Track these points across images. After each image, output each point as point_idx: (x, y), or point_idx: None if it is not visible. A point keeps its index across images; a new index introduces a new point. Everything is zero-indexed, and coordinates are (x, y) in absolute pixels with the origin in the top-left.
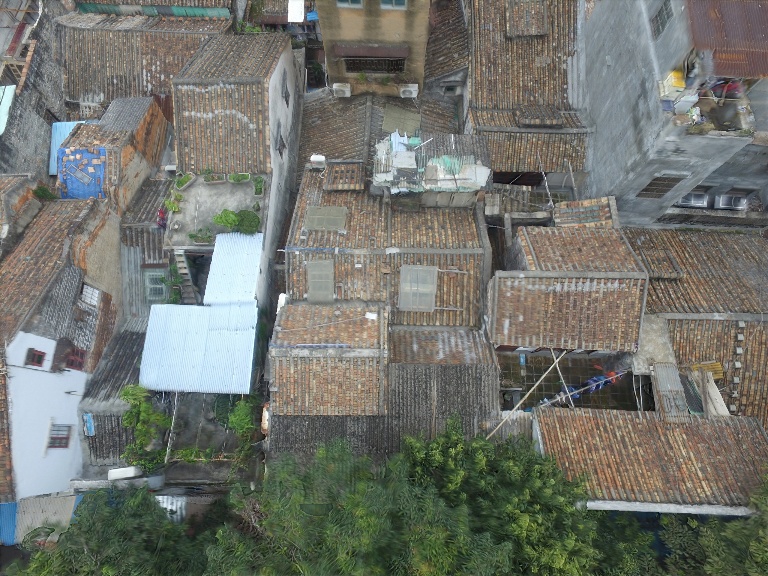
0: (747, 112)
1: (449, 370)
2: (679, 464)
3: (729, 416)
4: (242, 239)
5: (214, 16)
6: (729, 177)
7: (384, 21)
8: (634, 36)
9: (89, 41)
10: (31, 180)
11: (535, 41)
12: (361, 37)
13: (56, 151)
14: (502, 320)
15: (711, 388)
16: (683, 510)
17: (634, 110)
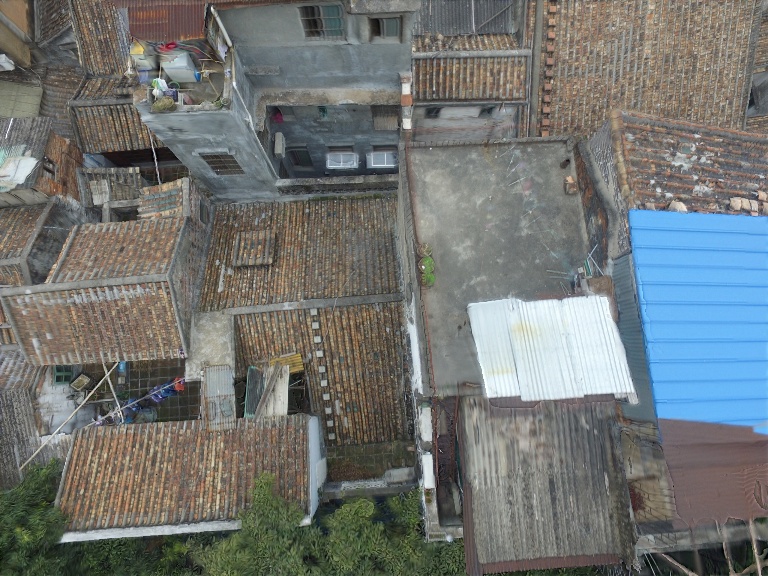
0: (229, 77)
1: None
2: (202, 477)
3: (282, 416)
4: None
5: None
6: (354, 135)
7: None
8: None
9: None
10: None
11: None
12: None
13: None
14: (30, 340)
15: (281, 384)
16: (178, 531)
17: None
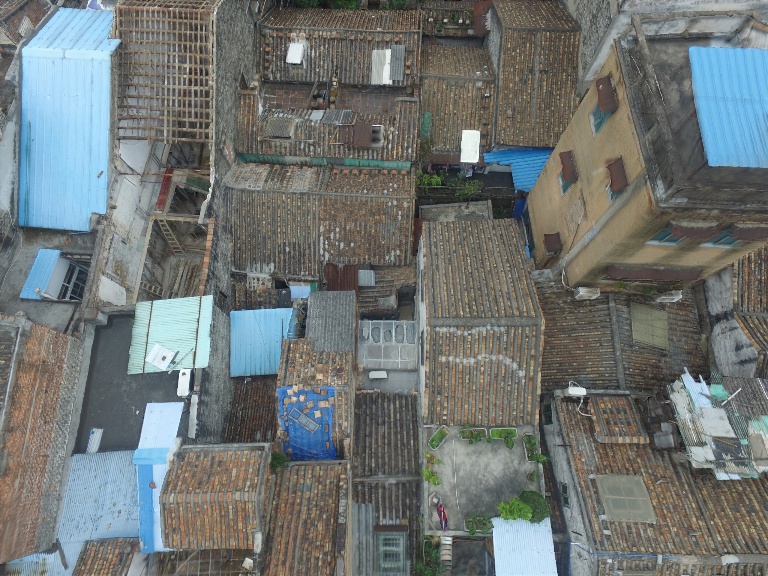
0: None
1: None
2: None
3: None
4: (525, 526)
5: (390, 167)
6: None
7: (691, 254)
8: None
9: (258, 204)
10: (268, 452)
11: None
12: (649, 262)
13: (236, 347)
14: None
15: None
16: None
17: None
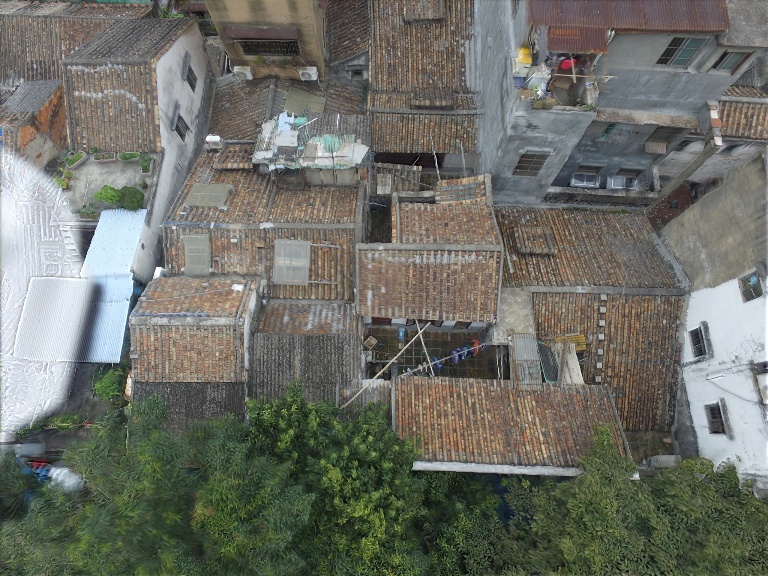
0: (593, 88)
1: (312, 340)
2: (523, 429)
3: (582, 384)
4: (126, 215)
5: (136, 3)
6: (614, 157)
7: (267, 3)
8: (502, 16)
9: (9, 27)
10: None
11: (433, 25)
12: (249, 19)
13: None
14: (365, 292)
15: (571, 359)
16: (516, 471)
17: (502, 89)
